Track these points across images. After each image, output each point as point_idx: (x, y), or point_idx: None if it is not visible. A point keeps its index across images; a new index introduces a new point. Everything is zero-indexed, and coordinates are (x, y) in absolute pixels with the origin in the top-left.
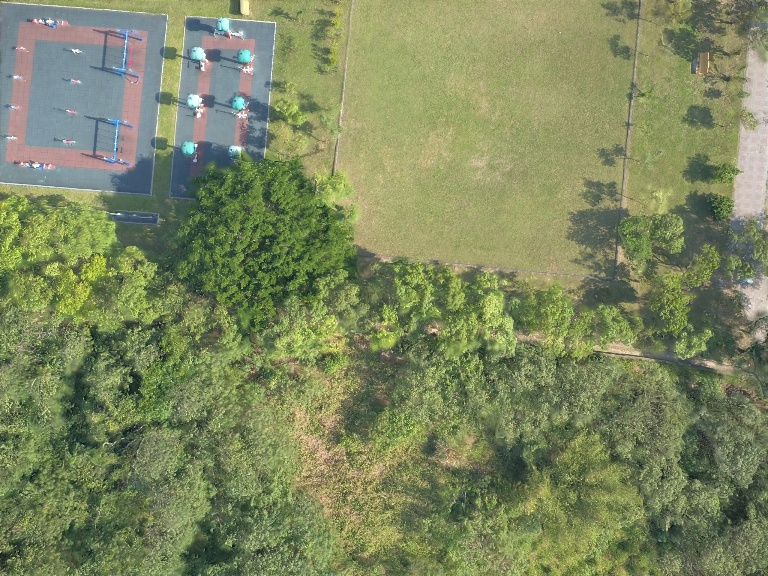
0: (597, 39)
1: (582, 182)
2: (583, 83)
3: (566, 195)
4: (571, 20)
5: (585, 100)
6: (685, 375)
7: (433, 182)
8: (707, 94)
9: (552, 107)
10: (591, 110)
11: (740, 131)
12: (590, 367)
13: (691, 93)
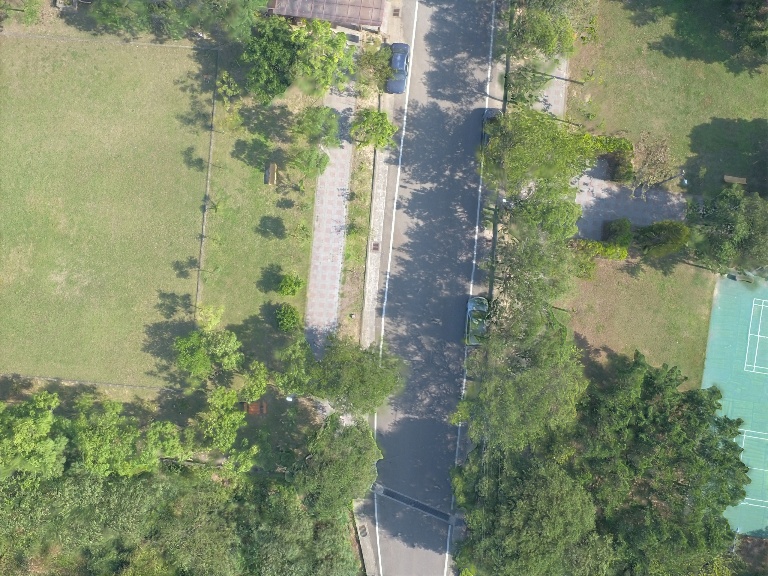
0: (171, 152)
1: (157, 295)
2: (158, 196)
3: (142, 308)
4: (146, 134)
5: (160, 213)
6: (261, 483)
7: (14, 298)
8: (280, 204)
9: (128, 221)
10: (166, 223)
11: (312, 240)
12: (138, 484)
13: (264, 203)
